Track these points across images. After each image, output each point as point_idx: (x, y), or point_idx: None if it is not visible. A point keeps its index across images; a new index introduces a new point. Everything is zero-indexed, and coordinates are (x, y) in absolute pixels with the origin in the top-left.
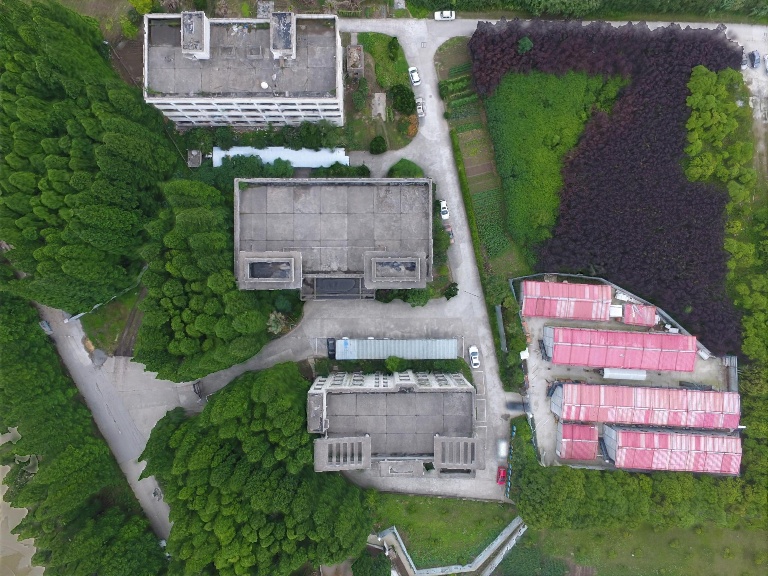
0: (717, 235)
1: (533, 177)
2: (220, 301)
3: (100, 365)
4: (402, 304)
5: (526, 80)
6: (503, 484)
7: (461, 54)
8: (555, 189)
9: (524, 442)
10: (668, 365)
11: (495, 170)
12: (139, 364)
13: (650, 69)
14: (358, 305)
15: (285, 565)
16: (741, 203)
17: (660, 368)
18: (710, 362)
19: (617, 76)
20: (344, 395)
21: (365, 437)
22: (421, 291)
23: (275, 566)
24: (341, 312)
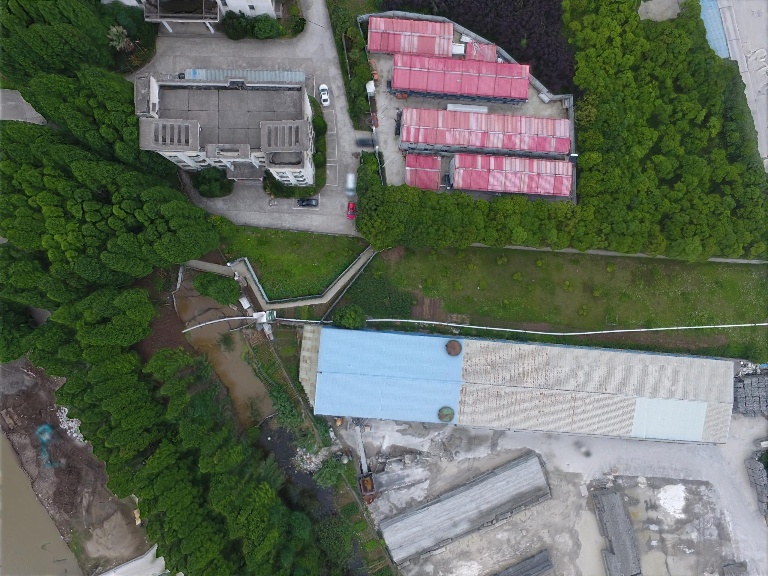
0: None
1: None
2: None
3: None
4: (254, 44)
5: None
6: (353, 219)
7: None
8: None
9: (370, 171)
10: (503, 92)
11: None
12: None
13: None
14: (210, 43)
15: (112, 241)
16: None
17: (496, 95)
18: (551, 106)
19: None
20: (177, 90)
21: (192, 120)
22: (267, 20)
23: (104, 248)
24: (193, 50)
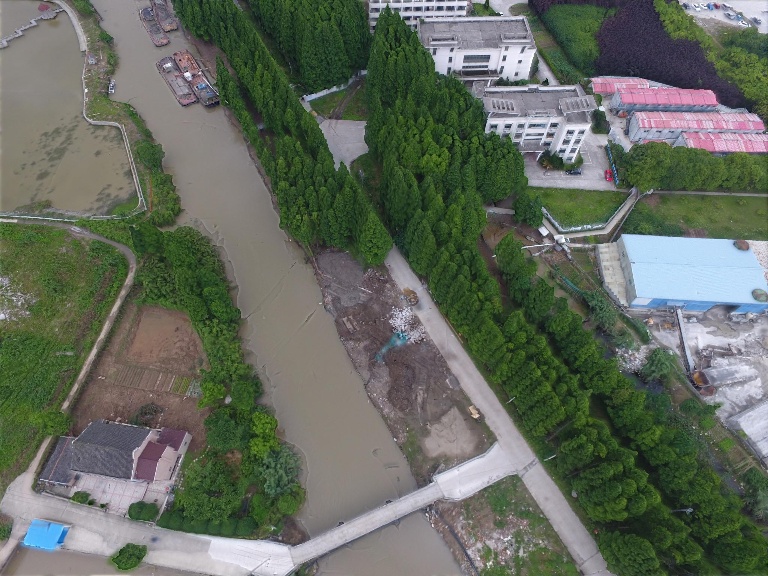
0: (701, 56)
1: (579, 41)
2: (415, 51)
3: (320, 123)
4: None
5: (563, 6)
6: (611, 181)
7: (523, 8)
8: (594, 45)
9: None
10: (700, 102)
11: (555, 44)
12: (345, 123)
13: (629, 0)
14: None
15: None
16: (709, 48)
17: (695, 104)
18: None
19: (612, 8)
20: (494, 94)
21: (514, 100)
22: None
23: None
24: None
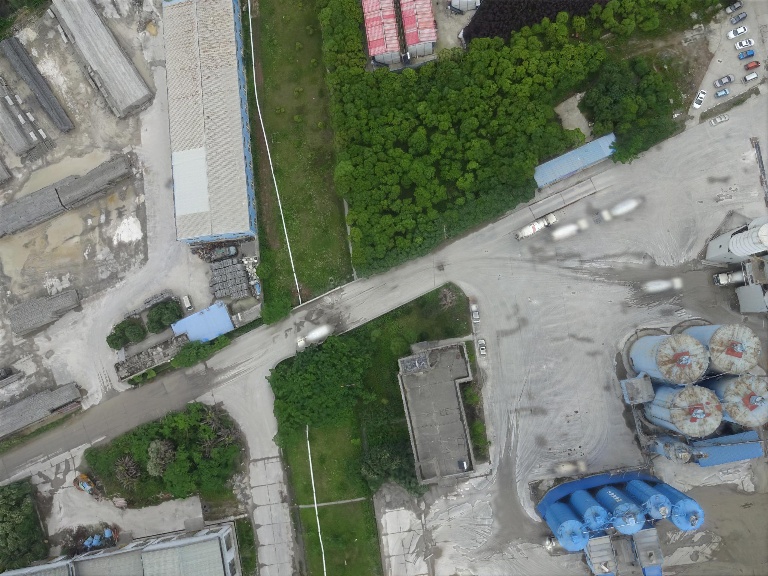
0: (568, 3)
1: None
2: None
3: None
4: None
5: None
6: None
7: None
8: None
9: None
10: None
11: None
12: None
13: None
14: None
15: None
16: None
17: None
18: (457, 42)
19: None
20: None
21: None
22: None
23: None
24: None
